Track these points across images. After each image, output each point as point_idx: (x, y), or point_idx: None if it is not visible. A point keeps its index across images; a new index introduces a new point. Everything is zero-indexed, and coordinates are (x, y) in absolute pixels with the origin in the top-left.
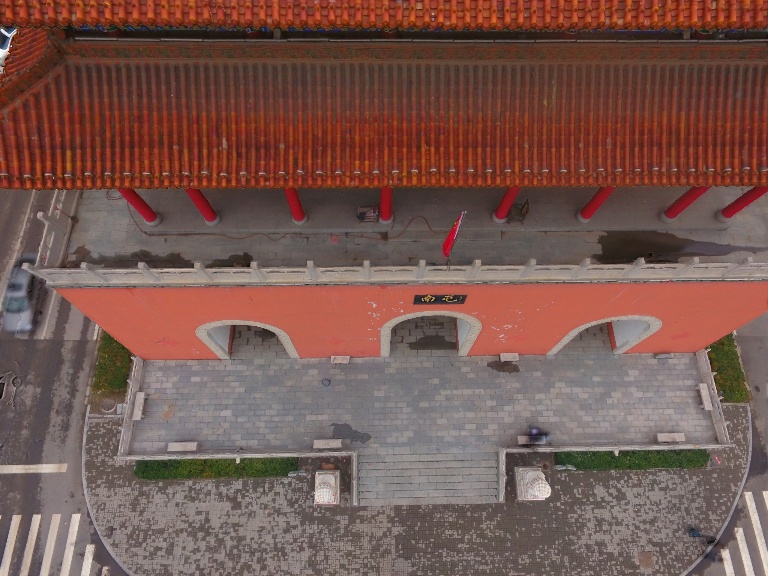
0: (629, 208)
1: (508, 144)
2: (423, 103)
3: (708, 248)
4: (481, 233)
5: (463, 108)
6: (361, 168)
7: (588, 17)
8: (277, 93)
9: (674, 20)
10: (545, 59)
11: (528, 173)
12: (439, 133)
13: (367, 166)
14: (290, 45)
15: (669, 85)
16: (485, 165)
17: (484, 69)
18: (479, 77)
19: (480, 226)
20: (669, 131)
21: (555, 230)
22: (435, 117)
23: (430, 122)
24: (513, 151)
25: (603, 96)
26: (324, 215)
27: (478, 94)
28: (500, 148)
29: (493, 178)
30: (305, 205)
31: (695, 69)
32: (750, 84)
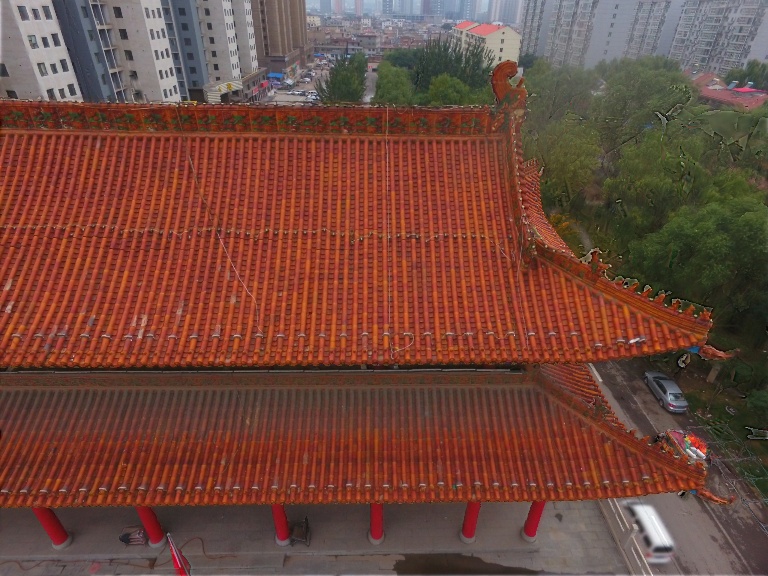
0: (428, 526)
1: (205, 460)
2: (133, 423)
3: (519, 575)
4: (261, 558)
5: (170, 427)
6: (51, 486)
7: (199, 358)
8: (2, 415)
9: (273, 359)
10: (250, 385)
11: (219, 490)
12: (141, 450)
13: (57, 484)
14: (21, 376)
15: (364, 405)
16: (178, 482)
17: (197, 393)
18: (190, 400)
19: (260, 549)
20: (365, 447)
21: (347, 553)
22: (143, 435)
23: (135, 440)
24: (209, 467)
25: (302, 415)
26: (93, 537)
27: (187, 414)
28: (197, 464)
29: (183, 496)
30: (78, 525)
31: (385, 392)
32: (436, 404)
